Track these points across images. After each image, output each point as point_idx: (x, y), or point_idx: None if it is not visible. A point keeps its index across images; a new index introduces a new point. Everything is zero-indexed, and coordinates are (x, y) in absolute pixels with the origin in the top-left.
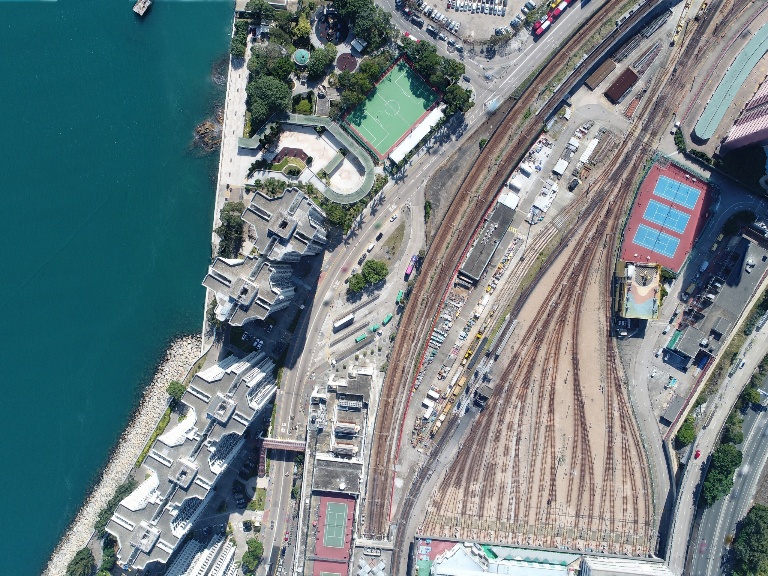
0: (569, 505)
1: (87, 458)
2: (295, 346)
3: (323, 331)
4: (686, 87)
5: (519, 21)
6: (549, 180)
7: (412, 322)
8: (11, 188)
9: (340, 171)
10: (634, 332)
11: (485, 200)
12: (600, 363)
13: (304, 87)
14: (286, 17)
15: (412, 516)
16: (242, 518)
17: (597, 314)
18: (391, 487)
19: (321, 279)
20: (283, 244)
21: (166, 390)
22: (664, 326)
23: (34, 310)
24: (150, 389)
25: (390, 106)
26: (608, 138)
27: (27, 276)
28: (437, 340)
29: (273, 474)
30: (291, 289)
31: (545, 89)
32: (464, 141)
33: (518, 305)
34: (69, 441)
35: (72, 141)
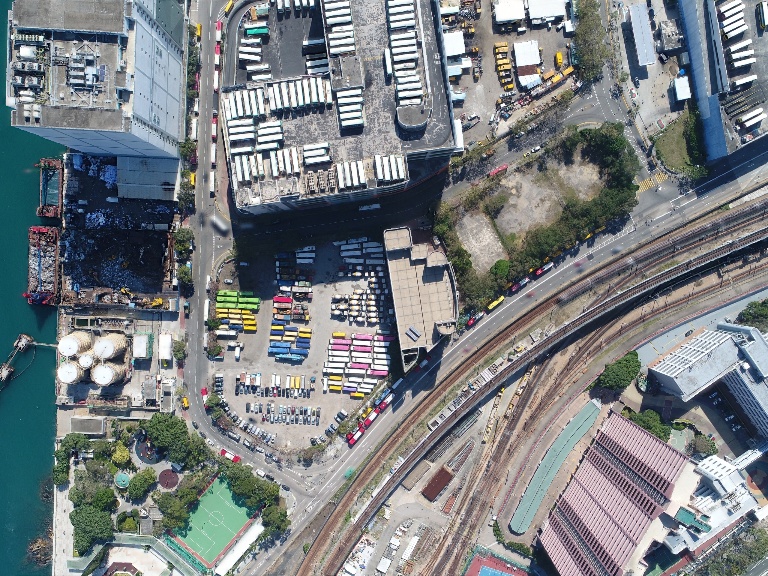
0: None
1: None
2: None
3: None
4: (501, 481)
5: (332, 431)
6: None
7: None
8: None
9: None
10: None
11: None
12: None
13: (129, 504)
14: (102, 449)
15: None
16: None
17: None
18: None
19: None
20: None
21: None
22: None
23: None
24: None
25: (214, 517)
26: (428, 535)
27: None
28: None
29: None
30: None
31: (363, 492)
32: (288, 546)
33: None
34: None
35: None
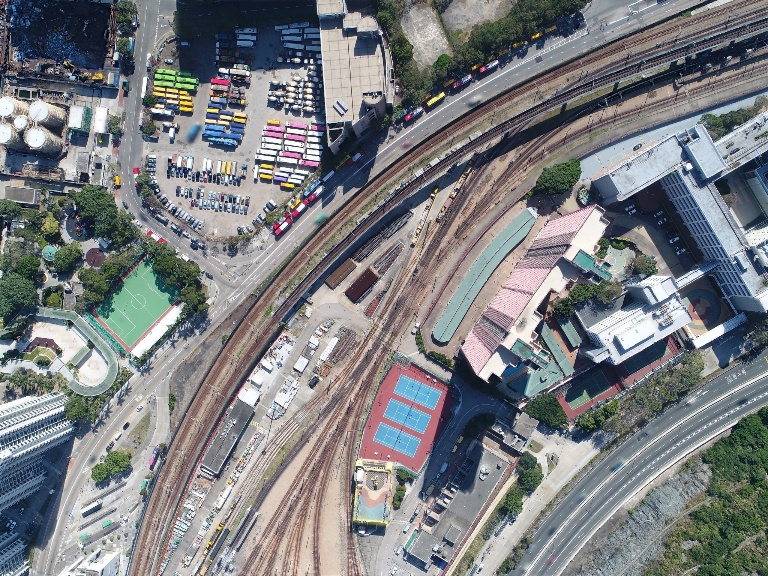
0: None
1: None
2: (46, 528)
3: (73, 514)
4: (427, 288)
5: (260, 221)
6: (289, 377)
7: (157, 510)
8: None
9: (89, 361)
10: (373, 530)
11: (224, 396)
12: (341, 558)
13: (55, 280)
14: (32, 217)
15: None
16: None
17: (338, 510)
18: None
19: (71, 465)
20: None
21: None
22: (405, 525)
23: None
24: None
25: (137, 300)
26: (348, 337)
27: None
28: (180, 529)
29: None
30: (32, 480)
31: (286, 287)
32: (207, 336)
33: (260, 498)
34: None
35: None
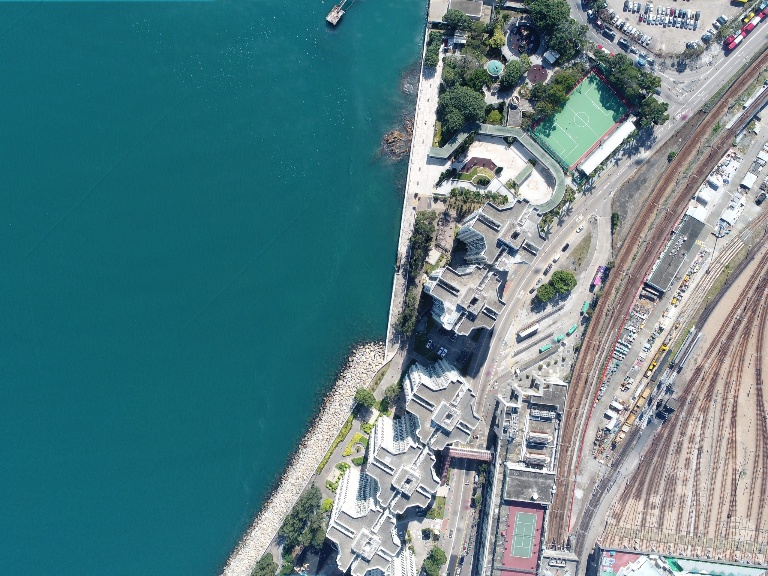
0: (749, 519)
1: (267, 463)
2: (479, 355)
3: (506, 340)
4: None
5: (711, 35)
6: (737, 194)
7: (596, 333)
8: (213, 194)
9: (528, 181)
10: None
11: (674, 213)
12: None
13: (494, 98)
14: (483, 28)
15: (591, 527)
16: (421, 526)
17: None
18: (571, 498)
19: (506, 289)
20: (511, 254)
21: (356, 397)
22: None
23: (233, 315)
24: (331, 395)
25: (579, 118)
26: None
27: (227, 281)
28: (621, 351)
29: (453, 483)
30: None
31: (735, 103)
32: (653, 153)
33: (703, 318)
34: (249, 446)
35: (275, 148)
